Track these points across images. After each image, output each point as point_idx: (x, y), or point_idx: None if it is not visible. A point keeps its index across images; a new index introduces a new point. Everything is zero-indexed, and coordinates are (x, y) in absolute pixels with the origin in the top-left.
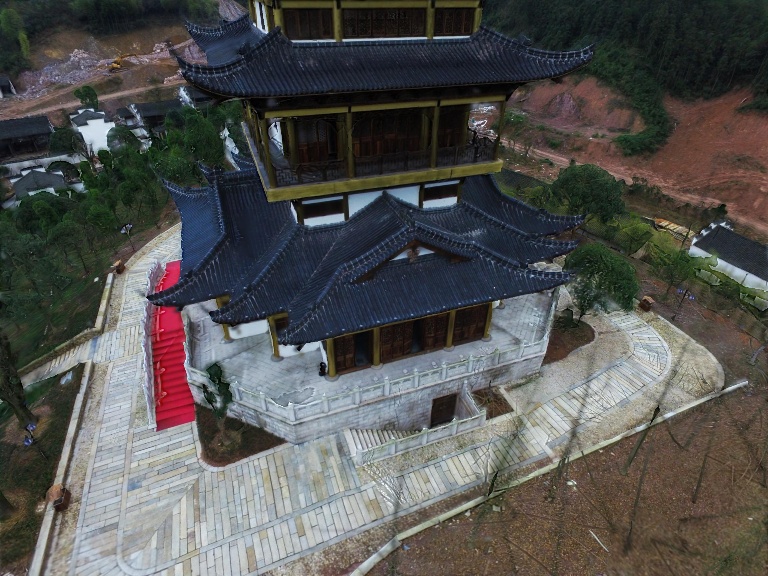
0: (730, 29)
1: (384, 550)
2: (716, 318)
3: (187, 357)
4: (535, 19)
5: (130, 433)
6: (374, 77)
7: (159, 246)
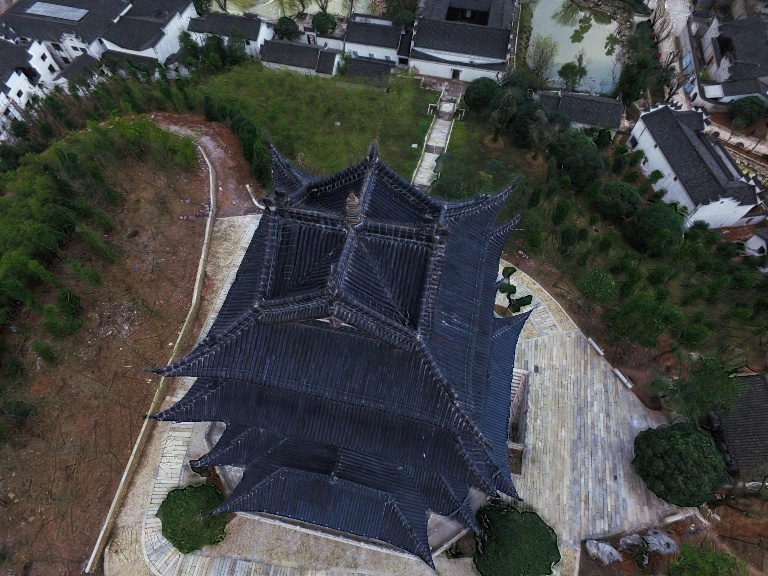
0: None
1: (194, 298)
2: None
3: None
4: None
5: None
6: None
7: (516, 280)
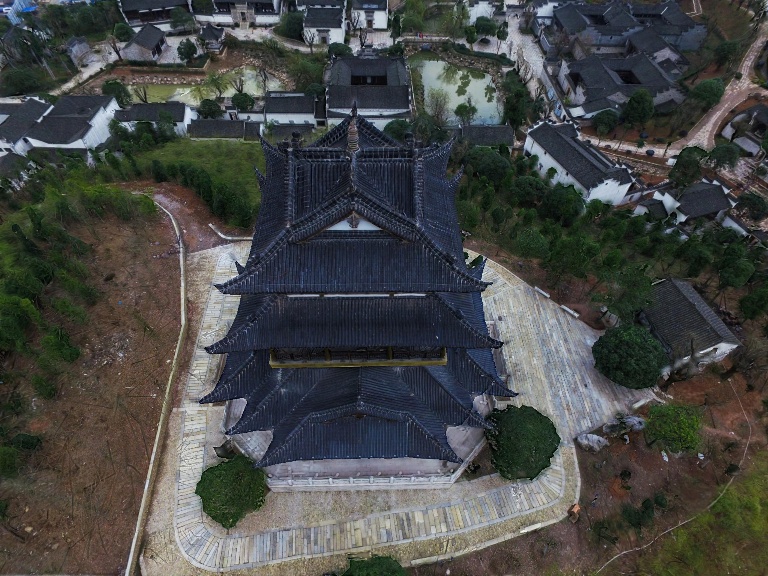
0: None
1: (183, 319)
2: None
3: None
4: None
5: None
6: None
7: None
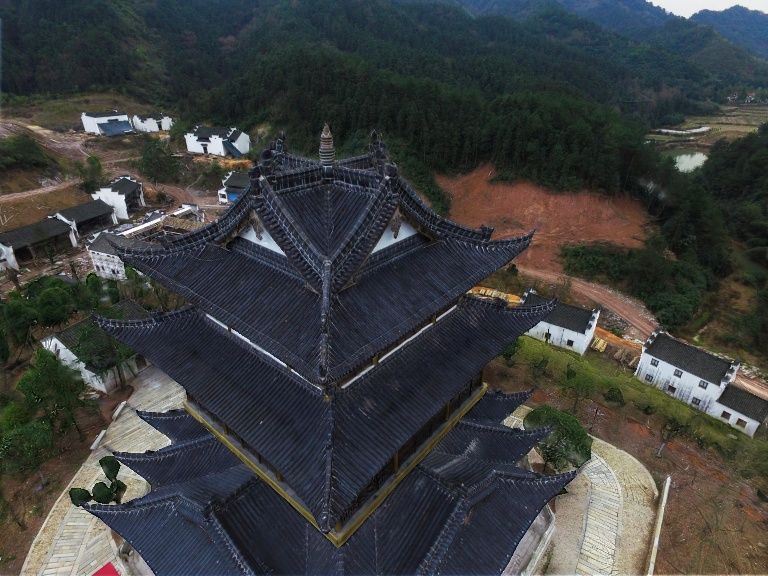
0: (462, 119)
1: None
2: (611, 415)
3: None
4: (306, 114)
5: None
6: (428, 396)
7: (47, 562)
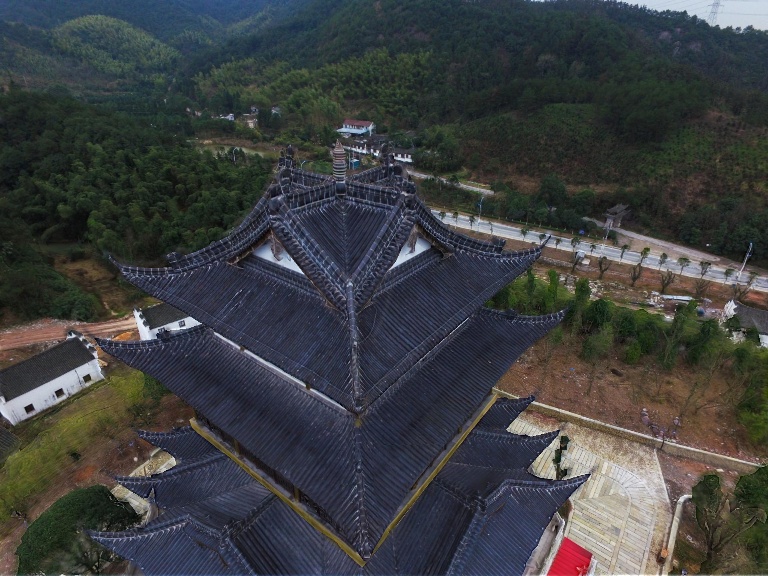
0: None
1: None
2: None
3: (559, 533)
4: None
5: (611, 572)
6: None
7: None
